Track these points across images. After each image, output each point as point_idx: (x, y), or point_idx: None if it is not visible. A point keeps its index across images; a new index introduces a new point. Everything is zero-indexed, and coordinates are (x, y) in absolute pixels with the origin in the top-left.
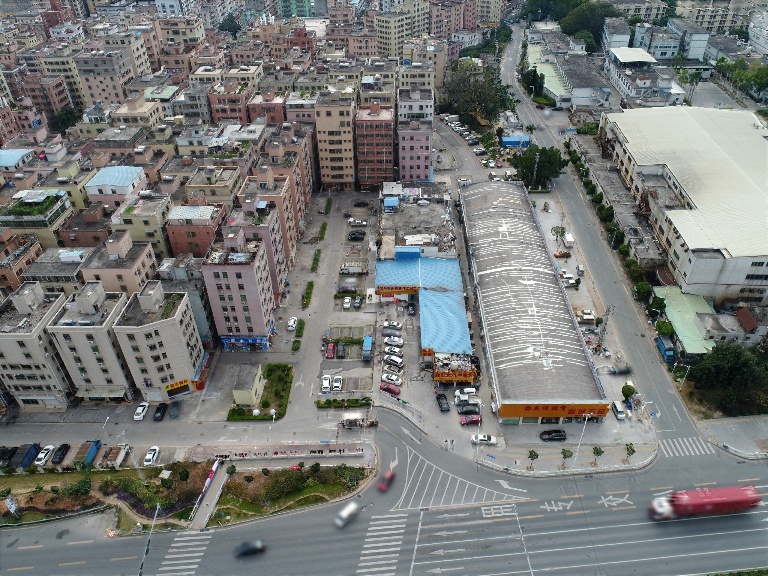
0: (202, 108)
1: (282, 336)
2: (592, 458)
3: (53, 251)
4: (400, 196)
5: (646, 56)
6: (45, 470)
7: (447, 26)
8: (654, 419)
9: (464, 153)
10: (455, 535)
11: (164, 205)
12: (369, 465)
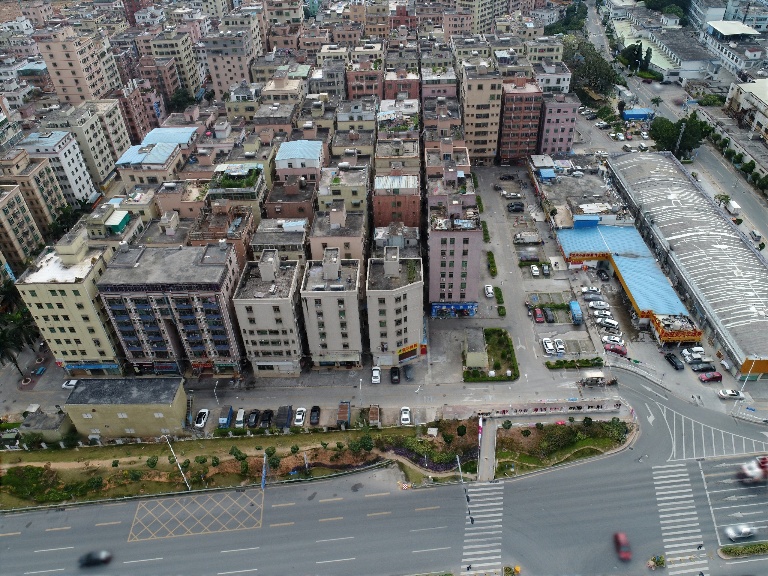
0: (339, 85)
1: (483, 303)
2: None
3: (268, 222)
4: (553, 168)
5: (747, 28)
6: (308, 430)
7: (522, 4)
8: None
9: (586, 127)
10: (741, 482)
11: (366, 176)
12: (631, 419)
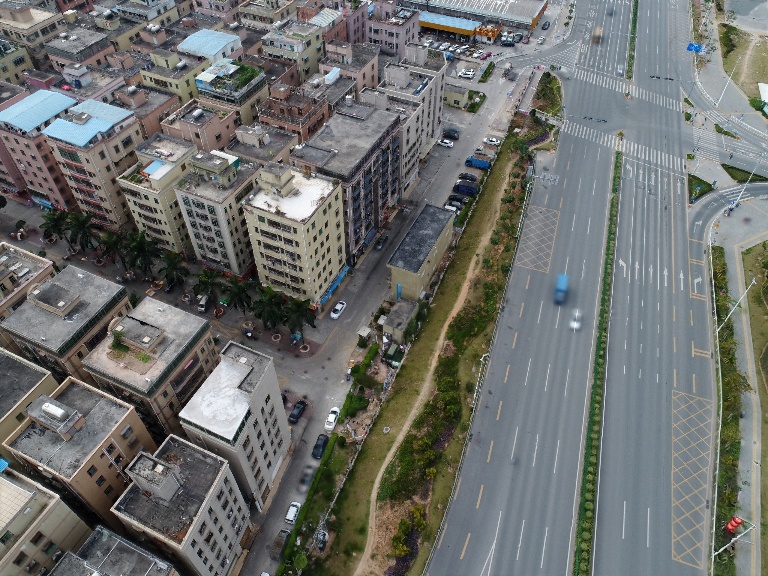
0: (50, 4)
1: None
2: (565, 21)
3: None
4: None
5: None
6: (482, 182)
7: None
8: (548, 3)
9: None
10: None
11: None
12: None
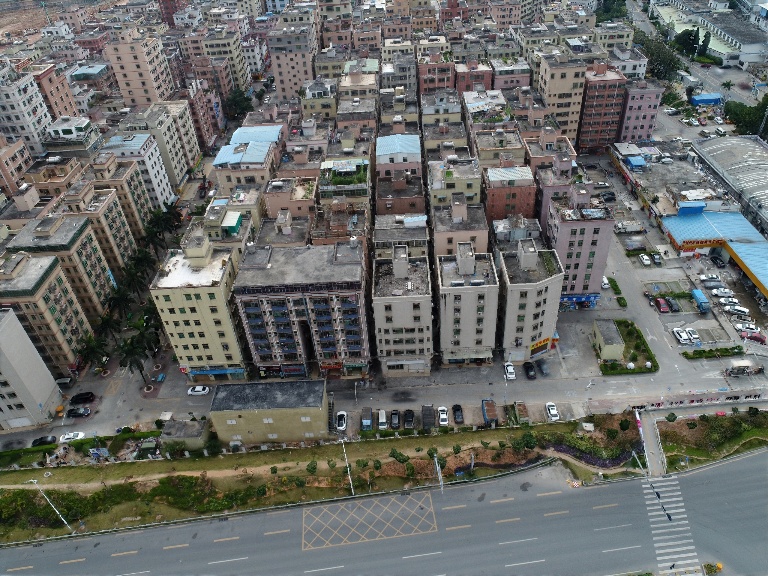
0: (410, 79)
1: None
2: None
3: (384, 218)
4: (641, 155)
5: None
6: None
7: None
8: None
9: None
10: None
11: None
12: None
